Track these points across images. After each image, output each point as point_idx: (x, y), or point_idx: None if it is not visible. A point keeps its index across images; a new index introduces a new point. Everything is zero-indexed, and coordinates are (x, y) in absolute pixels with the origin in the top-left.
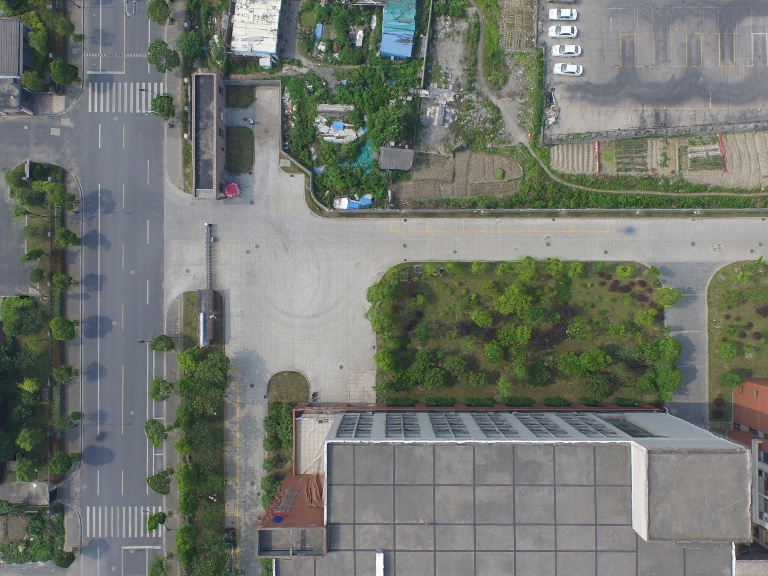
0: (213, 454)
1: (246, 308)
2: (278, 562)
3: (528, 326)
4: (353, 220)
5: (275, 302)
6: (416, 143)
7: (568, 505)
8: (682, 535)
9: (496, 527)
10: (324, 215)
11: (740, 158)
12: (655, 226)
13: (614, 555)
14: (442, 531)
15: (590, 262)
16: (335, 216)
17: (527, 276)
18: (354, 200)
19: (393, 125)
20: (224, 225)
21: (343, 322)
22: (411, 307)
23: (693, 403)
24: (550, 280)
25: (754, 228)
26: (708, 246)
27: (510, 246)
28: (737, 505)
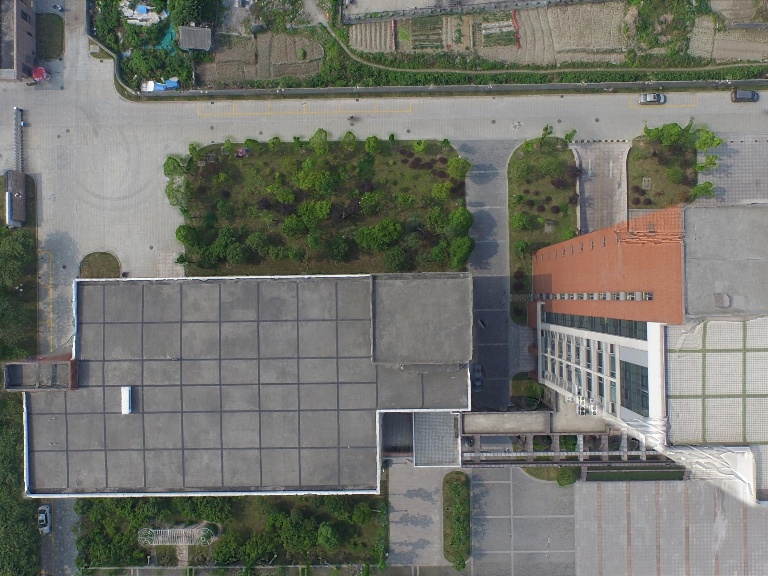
0: (16, 327)
1: (57, 191)
2: (30, 399)
3: (327, 201)
4: (161, 103)
5: (86, 185)
6: (218, 25)
7: (311, 339)
8: (407, 357)
9: (241, 361)
10: (133, 99)
11: (533, 34)
12: (456, 105)
13: (355, 386)
14: (189, 366)
15: (393, 141)
16: (143, 100)
17: (320, 148)
18: (160, 83)
19: (193, 6)
20: (35, 110)
21: (152, 203)
22: (213, 184)
23: (495, 277)
24: (353, 159)
25: (553, 105)
26: (508, 123)
27: (315, 126)
28: (460, 328)
